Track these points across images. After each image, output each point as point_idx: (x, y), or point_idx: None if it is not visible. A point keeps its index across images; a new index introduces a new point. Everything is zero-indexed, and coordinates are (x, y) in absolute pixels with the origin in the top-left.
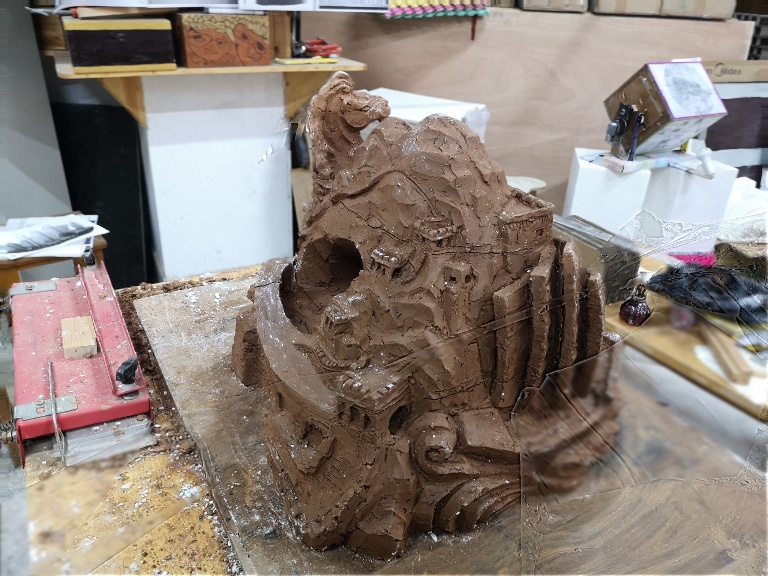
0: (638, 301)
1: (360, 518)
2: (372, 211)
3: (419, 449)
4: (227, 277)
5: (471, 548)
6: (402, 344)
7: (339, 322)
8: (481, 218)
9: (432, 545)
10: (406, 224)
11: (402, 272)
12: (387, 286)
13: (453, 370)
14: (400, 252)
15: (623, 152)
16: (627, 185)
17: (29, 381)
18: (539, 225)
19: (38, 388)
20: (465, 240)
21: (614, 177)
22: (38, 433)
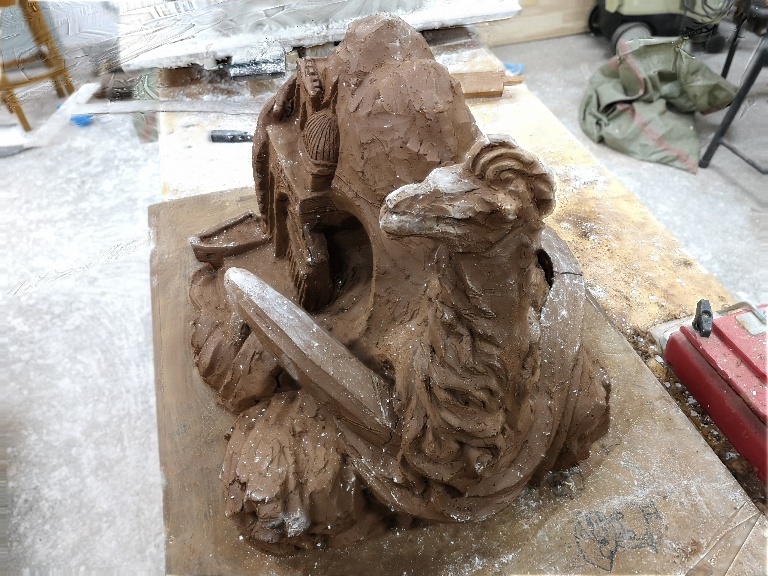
0: None
1: None
2: None
3: None
4: None
5: None
6: None
7: None
8: None
9: None
10: None
11: None
12: None
13: None
14: None
15: None
16: None
17: None
18: None
19: None
20: None
21: None
22: None
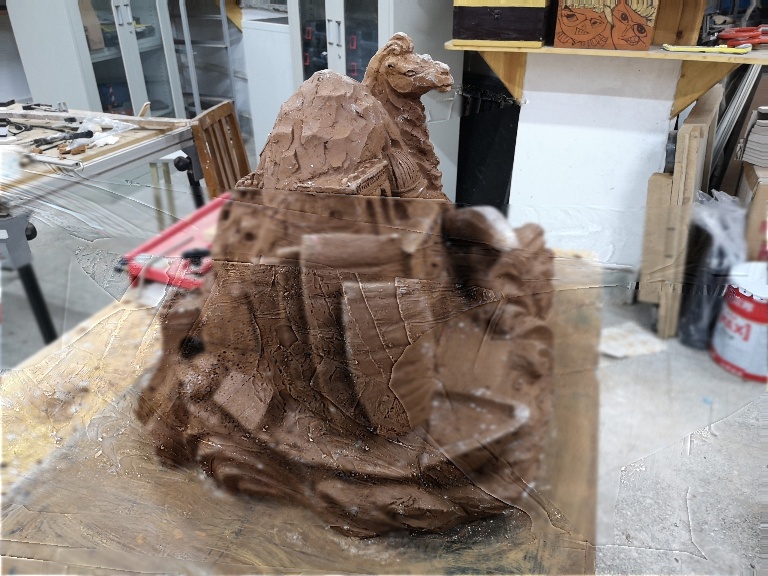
0: None
1: None
2: None
3: None
4: None
5: None
6: None
7: None
8: (280, 180)
9: None
10: None
11: None
12: None
13: None
14: None
15: None
16: None
17: None
18: None
19: None
20: None
21: None
22: None
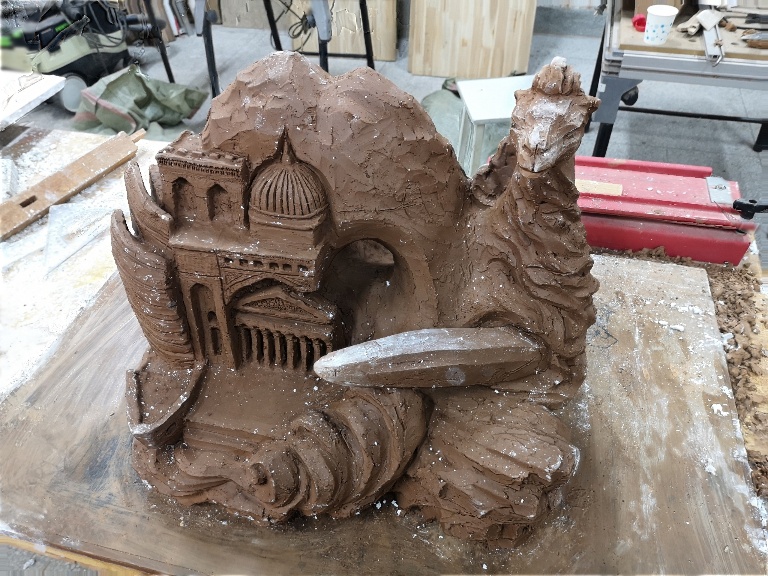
0: None
1: None
2: None
3: None
4: (766, 379)
5: None
6: None
7: None
8: None
9: None
10: None
11: None
12: None
13: None
14: None
15: None
16: None
17: None
18: None
19: None
20: None
21: None
22: None
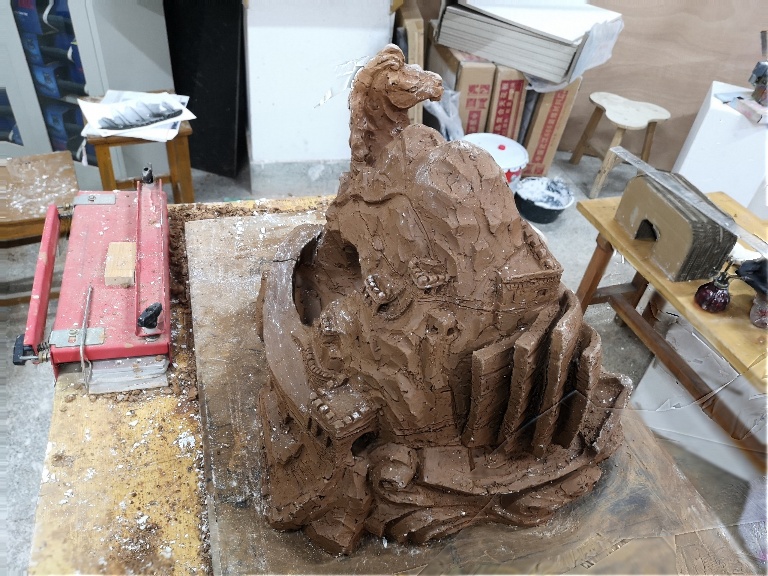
0: (719, 287)
1: (314, 518)
2: (378, 229)
3: (375, 477)
4: (280, 206)
5: (415, 562)
6: (375, 378)
7: (328, 333)
8: (477, 272)
9: (381, 550)
10: (403, 258)
11: (389, 307)
12: (371, 319)
13: (420, 414)
14: (392, 285)
15: (767, 97)
16: (761, 137)
17: (69, 305)
18: (542, 286)
19: (75, 314)
20: (456, 292)
21: (748, 125)
22: (68, 359)
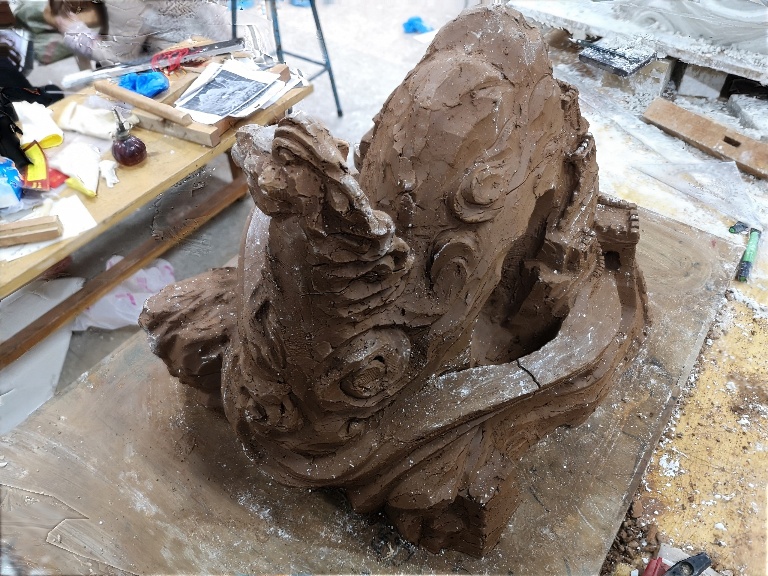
0: None
1: None
2: None
3: None
4: None
5: None
6: None
7: None
8: None
9: None
10: None
11: None
12: None
13: None
14: (570, 134)
15: None
16: None
17: None
18: None
19: None
20: None
21: None
22: None
